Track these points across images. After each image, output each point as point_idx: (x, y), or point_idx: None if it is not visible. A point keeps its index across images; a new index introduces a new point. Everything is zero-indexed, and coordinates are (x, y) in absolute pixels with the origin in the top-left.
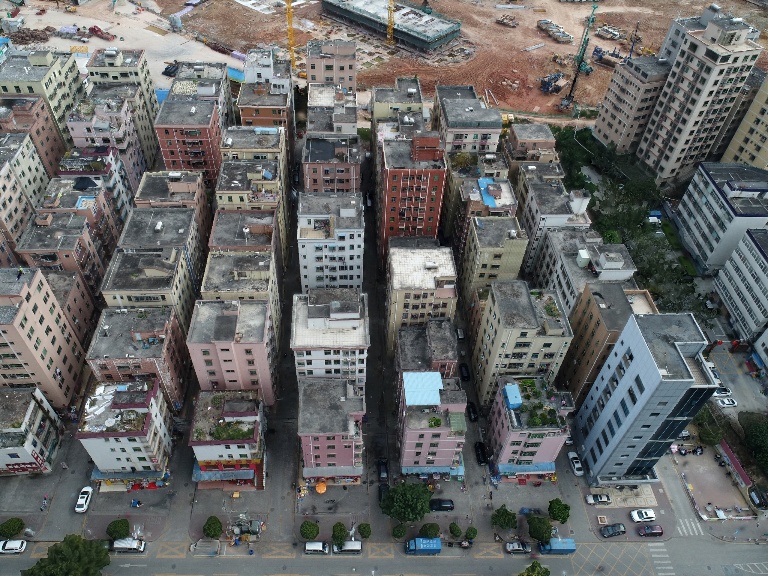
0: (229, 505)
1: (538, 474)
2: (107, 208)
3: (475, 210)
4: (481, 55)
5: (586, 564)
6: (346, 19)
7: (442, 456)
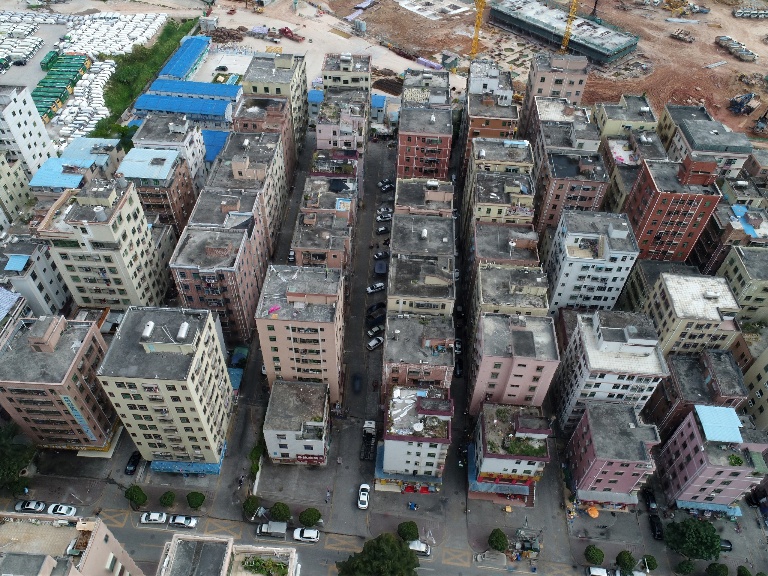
0: (502, 518)
1: None
2: (354, 210)
3: (734, 239)
4: (660, 70)
5: None
6: (515, 28)
7: (725, 494)
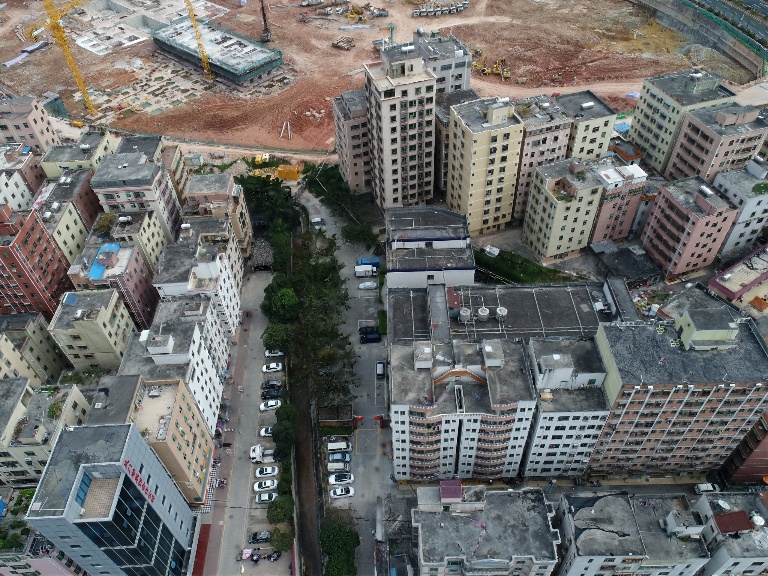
0: None
1: None
2: None
3: (80, 283)
4: (299, 84)
5: None
6: (174, 55)
7: None
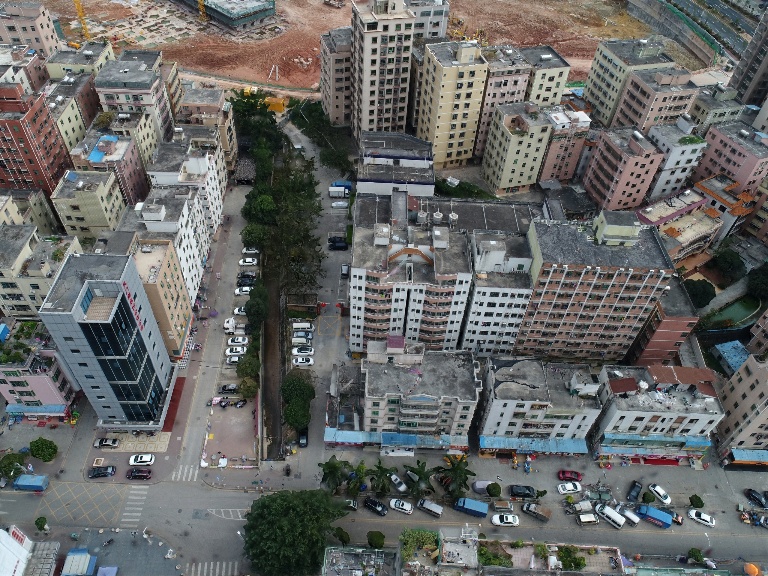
0: None
1: (59, 417)
2: None
3: (80, 165)
4: (290, 33)
5: (55, 501)
6: None
7: None
